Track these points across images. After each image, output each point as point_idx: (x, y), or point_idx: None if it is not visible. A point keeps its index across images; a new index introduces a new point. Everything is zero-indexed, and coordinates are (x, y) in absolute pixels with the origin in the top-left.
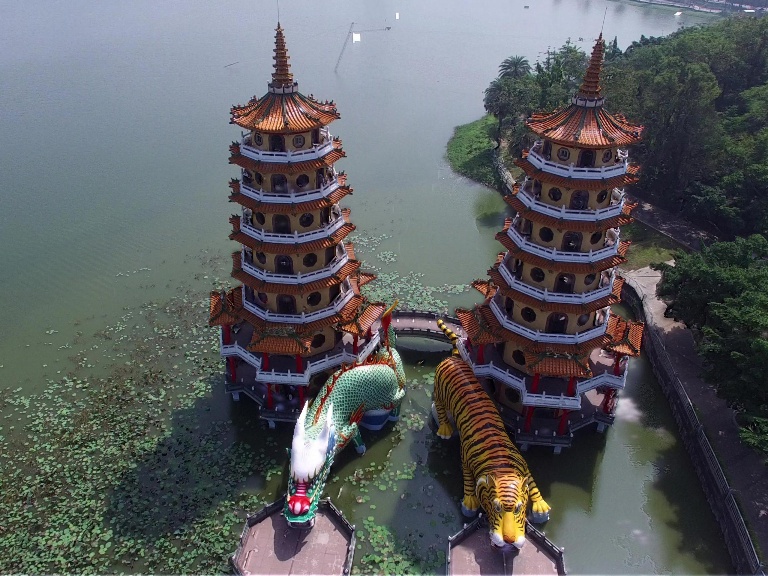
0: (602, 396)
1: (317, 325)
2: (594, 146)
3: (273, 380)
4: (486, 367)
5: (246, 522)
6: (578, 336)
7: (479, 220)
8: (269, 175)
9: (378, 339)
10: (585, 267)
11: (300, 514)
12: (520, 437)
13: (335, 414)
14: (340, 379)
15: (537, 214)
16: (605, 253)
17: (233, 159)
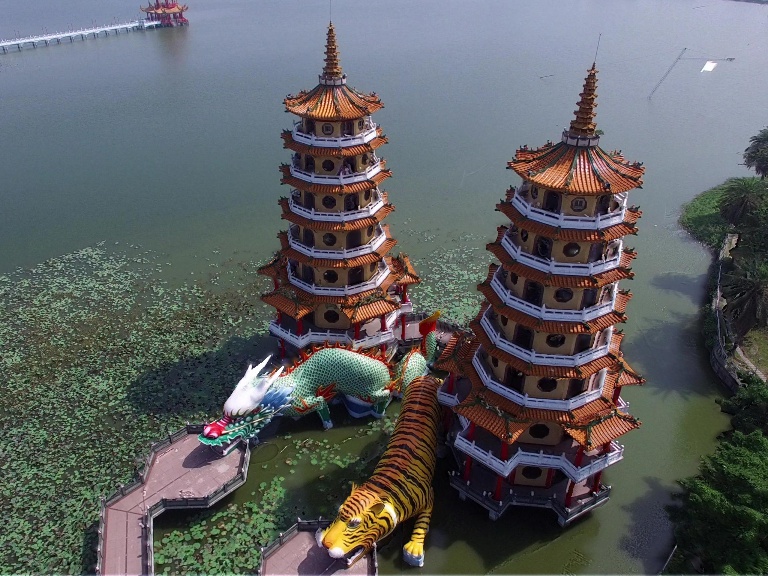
0: (587, 490)
1: (323, 299)
2: (546, 187)
3: (280, 334)
4: (451, 397)
5: (184, 427)
6: (527, 398)
7: (653, 277)
8: (304, 154)
9: (391, 337)
10: (533, 321)
11: (207, 437)
12: (454, 480)
13: (302, 380)
14: (319, 352)
15: (502, 250)
16: (567, 315)
17: (283, 135)
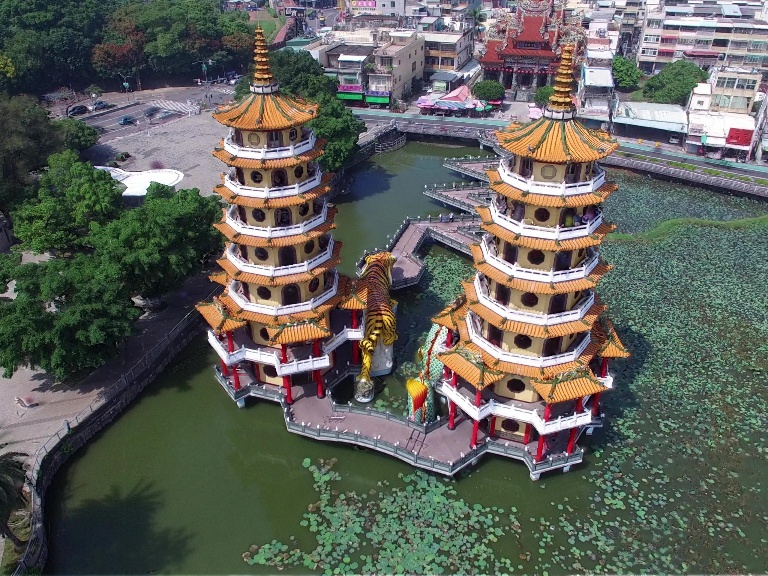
0: None
1: None
2: None
3: None
4: None
5: None
6: None
7: None
8: None
9: None
10: None
11: None
12: None
13: None
14: None
15: None
16: None
17: None
